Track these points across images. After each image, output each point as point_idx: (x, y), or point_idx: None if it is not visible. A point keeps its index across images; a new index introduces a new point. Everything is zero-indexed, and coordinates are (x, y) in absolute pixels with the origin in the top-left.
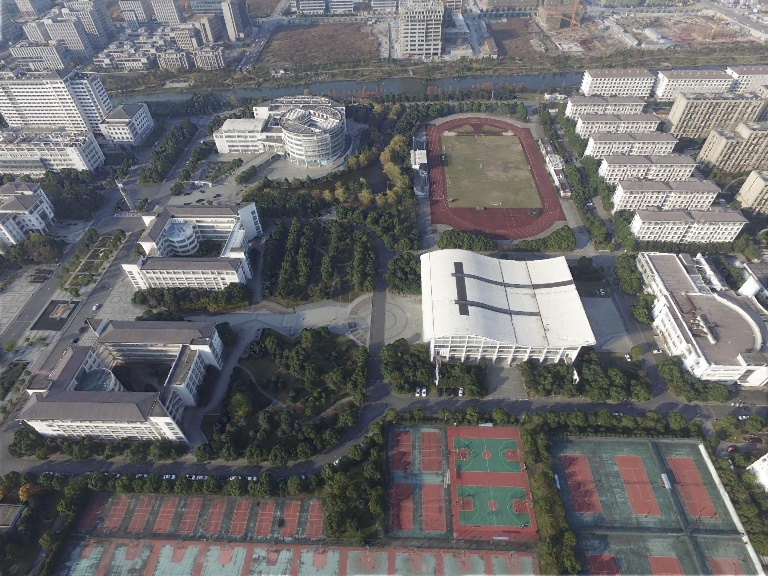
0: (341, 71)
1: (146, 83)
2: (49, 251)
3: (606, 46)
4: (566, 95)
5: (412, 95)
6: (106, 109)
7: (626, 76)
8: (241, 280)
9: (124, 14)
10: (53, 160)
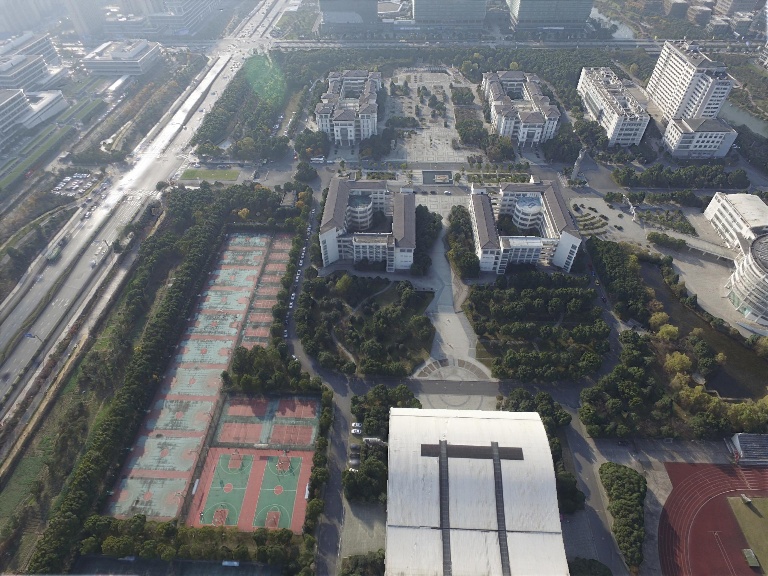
0: None
1: None
2: (497, 152)
3: None
4: None
5: None
6: (703, 114)
7: None
8: (485, 263)
9: None
10: (605, 116)
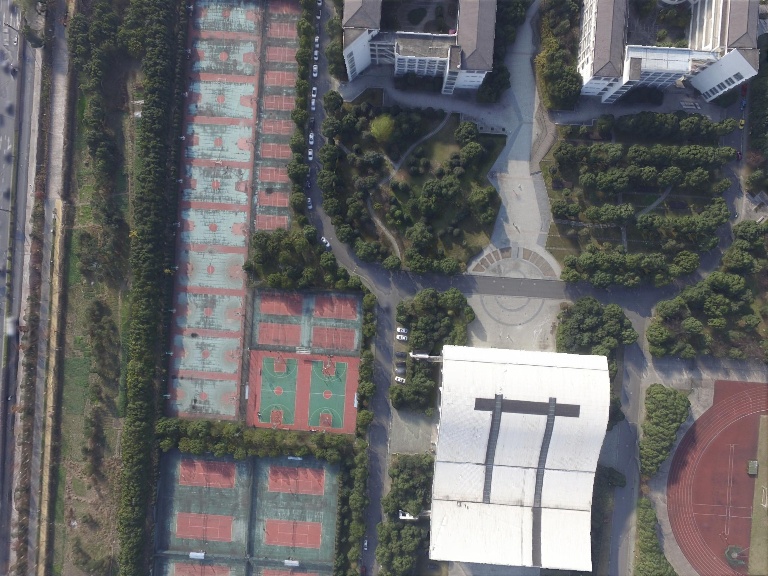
0: None
1: None
2: None
3: None
4: None
5: None
6: None
7: None
8: (591, 88)
9: None
10: None
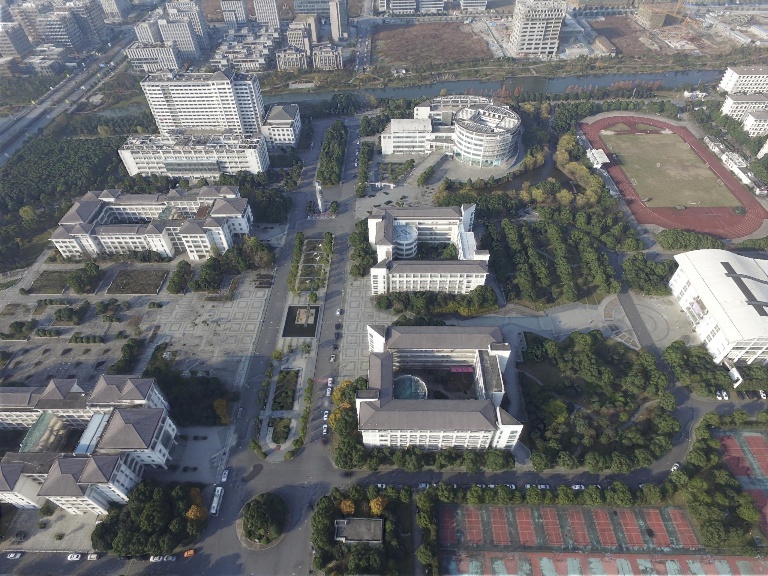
0: (463, 70)
1: (269, 84)
2: (266, 255)
3: (717, 44)
4: (706, 93)
5: (553, 94)
6: (261, 110)
7: None
8: None
9: (224, 14)
10: (228, 162)
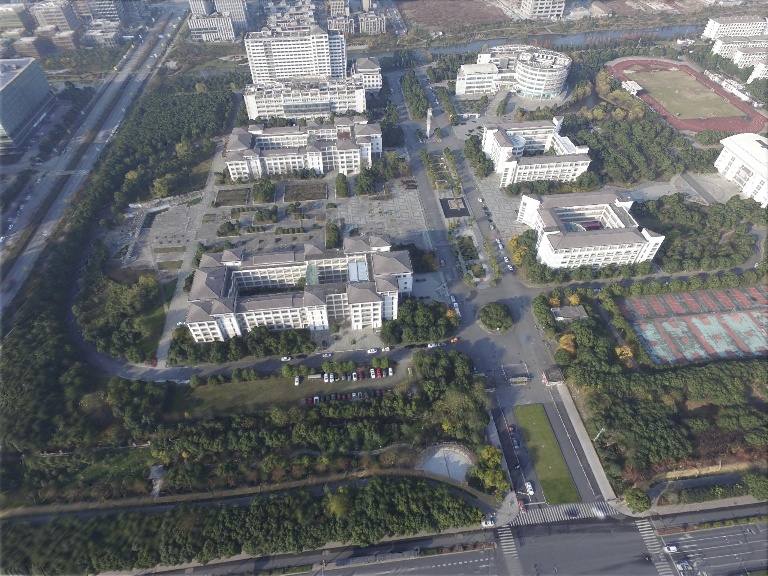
0: (490, 31)
1: None
2: None
3: (688, 5)
4: (694, 40)
5: (577, 45)
6: (346, 62)
7: (745, 22)
8: None
9: None
10: (338, 103)
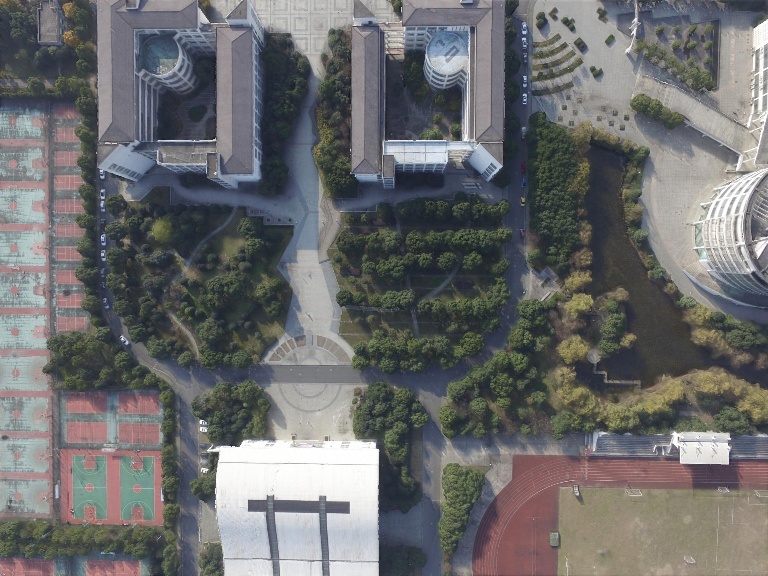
0: None
1: None
2: None
3: None
4: None
5: None
6: None
7: None
8: (365, 177)
9: None
10: None
